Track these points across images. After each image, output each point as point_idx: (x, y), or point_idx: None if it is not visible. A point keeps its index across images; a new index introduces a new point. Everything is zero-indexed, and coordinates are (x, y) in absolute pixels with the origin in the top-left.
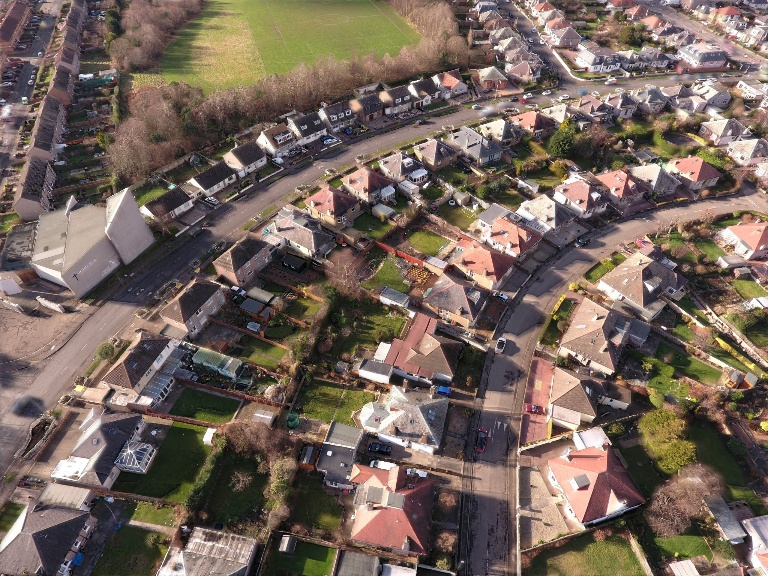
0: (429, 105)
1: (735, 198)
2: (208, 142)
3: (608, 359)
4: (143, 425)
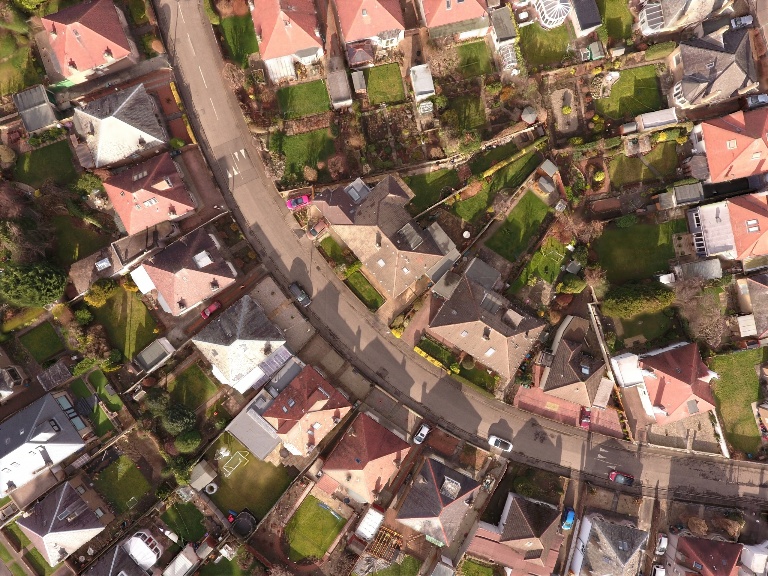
0: None
1: None
2: None
3: (535, 331)
4: None
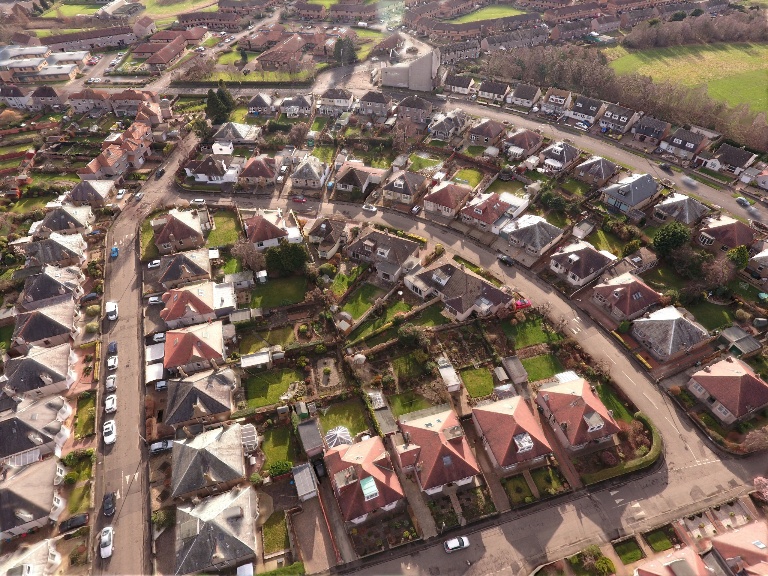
0: (711, 170)
1: (700, 440)
2: (539, 83)
3: None
4: (309, 111)
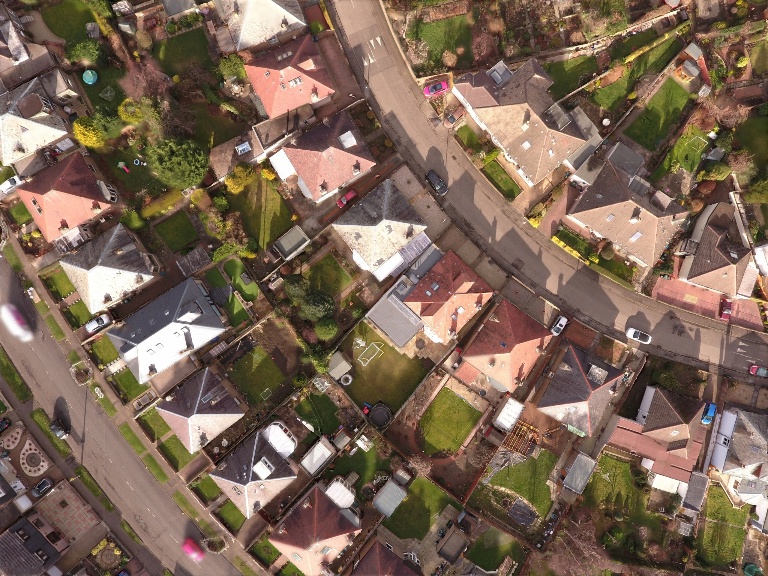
0: None
1: None
2: None
3: (680, 216)
4: None
